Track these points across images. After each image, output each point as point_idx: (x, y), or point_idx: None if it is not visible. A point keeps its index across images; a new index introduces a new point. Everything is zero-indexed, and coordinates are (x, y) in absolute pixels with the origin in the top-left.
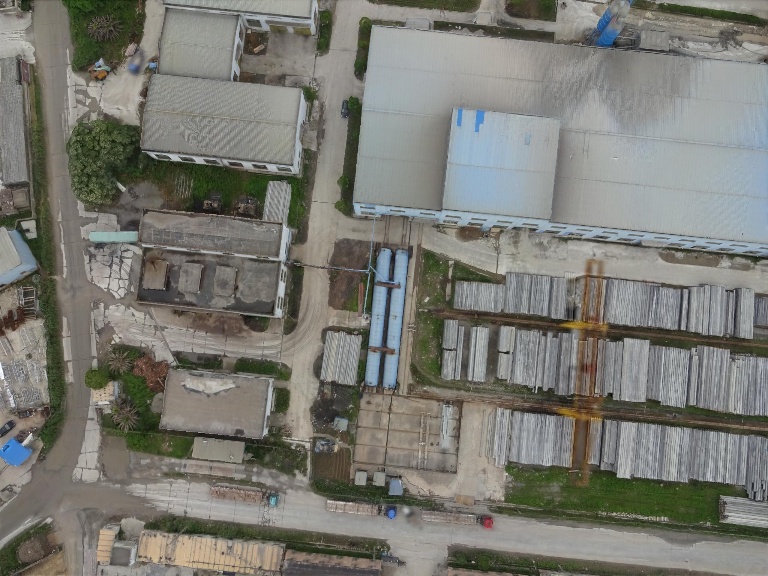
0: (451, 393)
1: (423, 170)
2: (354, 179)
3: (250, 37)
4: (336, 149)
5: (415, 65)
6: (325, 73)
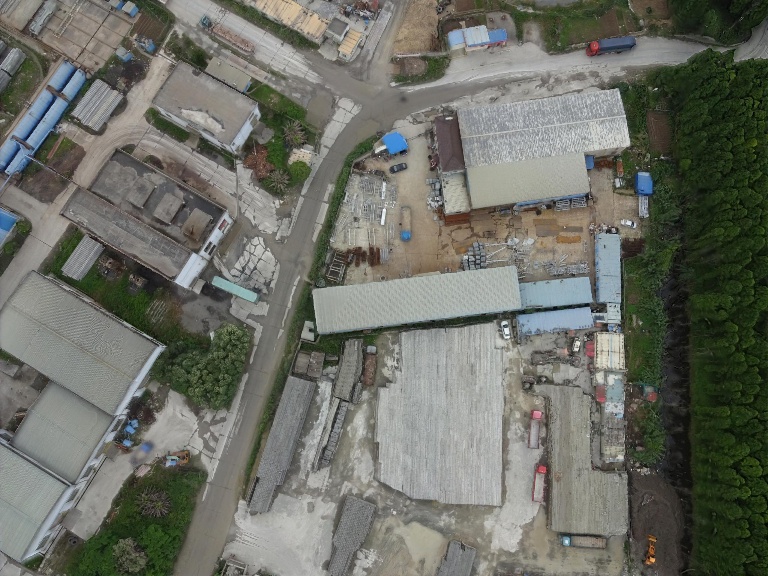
0: (26, 41)
1: None
2: None
3: None
4: (5, 285)
5: None
6: None
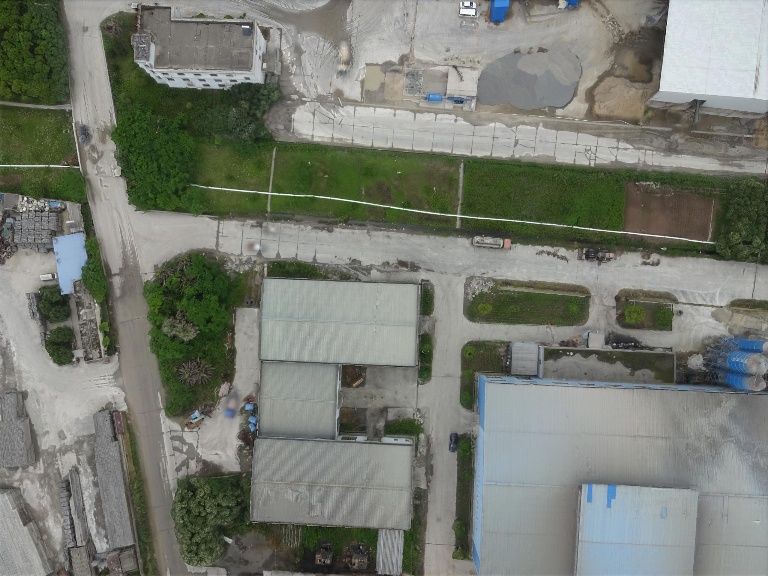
0: None
1: (551, 543)
2: (468, 517)
3: (347, 368)
4: (447, 486)
5: (535, 427)
6: (429, 403)
